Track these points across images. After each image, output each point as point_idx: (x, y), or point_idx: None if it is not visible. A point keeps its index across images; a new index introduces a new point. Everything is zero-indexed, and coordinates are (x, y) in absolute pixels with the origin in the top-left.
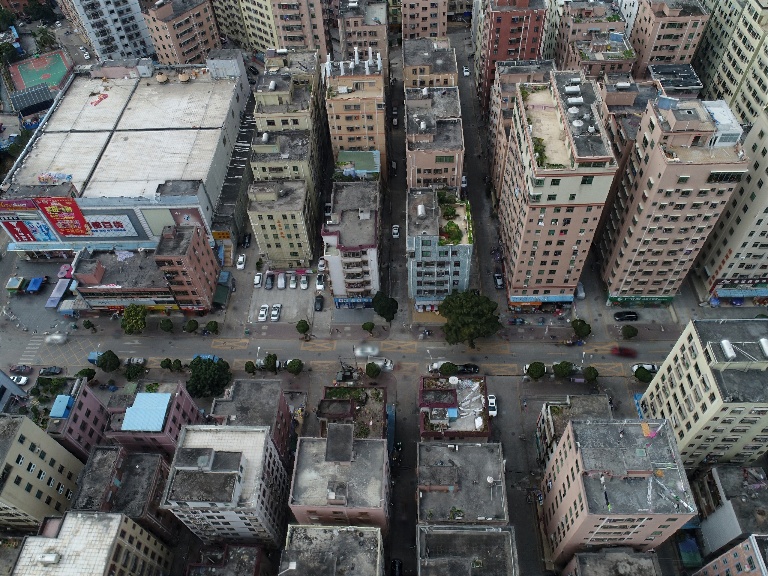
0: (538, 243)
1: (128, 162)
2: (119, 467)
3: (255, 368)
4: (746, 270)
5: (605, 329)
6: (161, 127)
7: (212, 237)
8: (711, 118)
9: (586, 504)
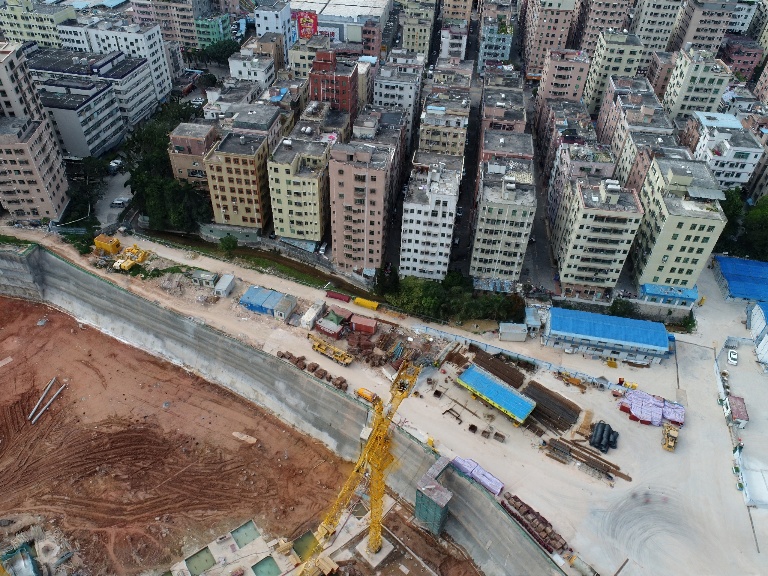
0: (543, 35)
1: (338, 12)
2: None
3: None
4: None
5: None
6: (352, 5)
7: None
8: None
9: (550, 59)
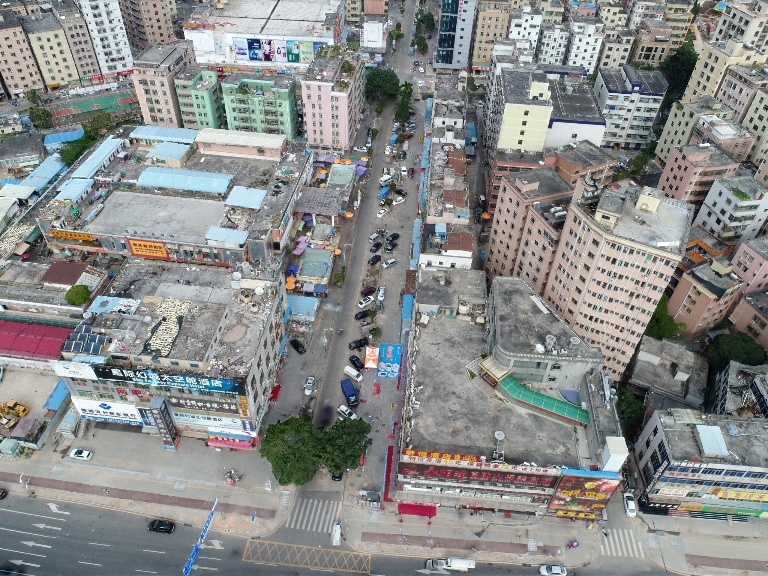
0: None
1: None
2: None
3: None
4: None
5: None
6: (272, 8)
7: None
8: None
9: None
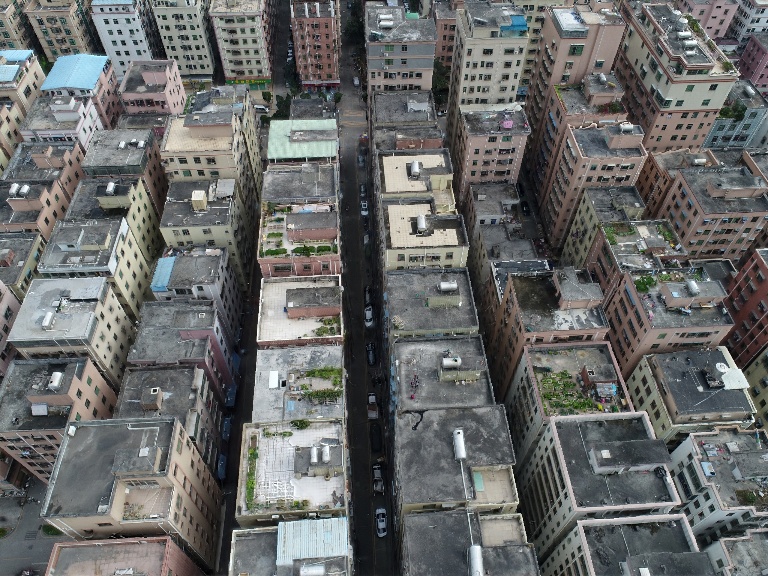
0: None
1: None
2: None
3: None
4: None
5: None
6: None
7: None
8: None
9: None
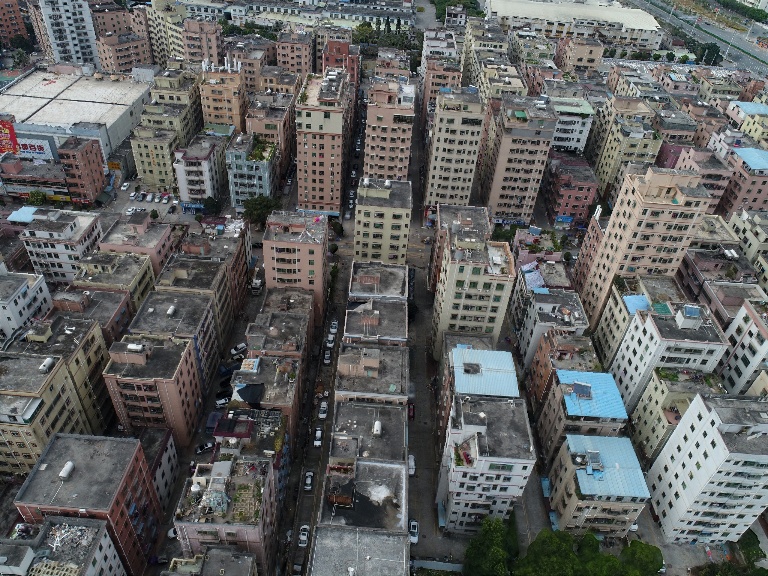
0: (307, 163)
1: (58, 114)
2: None
3: None
4: (441, 199)
5: None
6: (88, 100)
7: (107, 167)
8: (399, 88)
9: None
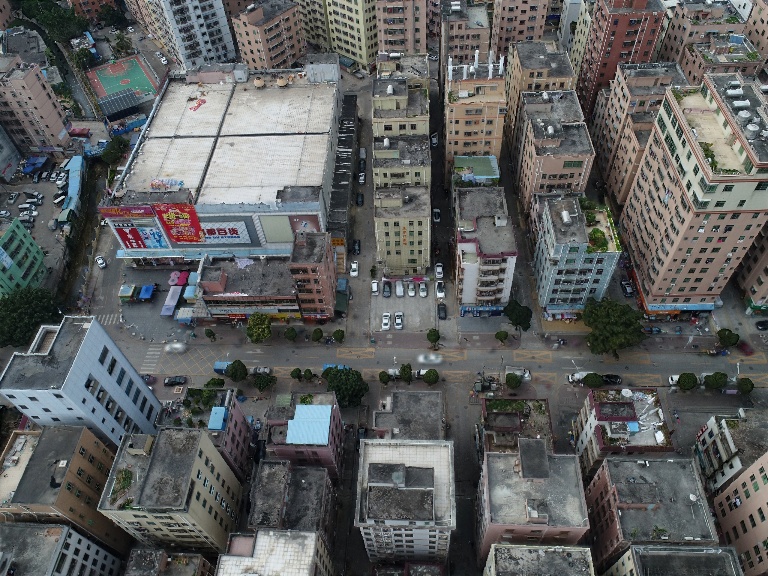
0: (692, 250)
1: (238, 168)
2: (289, 482)
3: (390, 378)
4: None
5: (748, 338)
6: (266, 132)
7: None
8: None
9: None
